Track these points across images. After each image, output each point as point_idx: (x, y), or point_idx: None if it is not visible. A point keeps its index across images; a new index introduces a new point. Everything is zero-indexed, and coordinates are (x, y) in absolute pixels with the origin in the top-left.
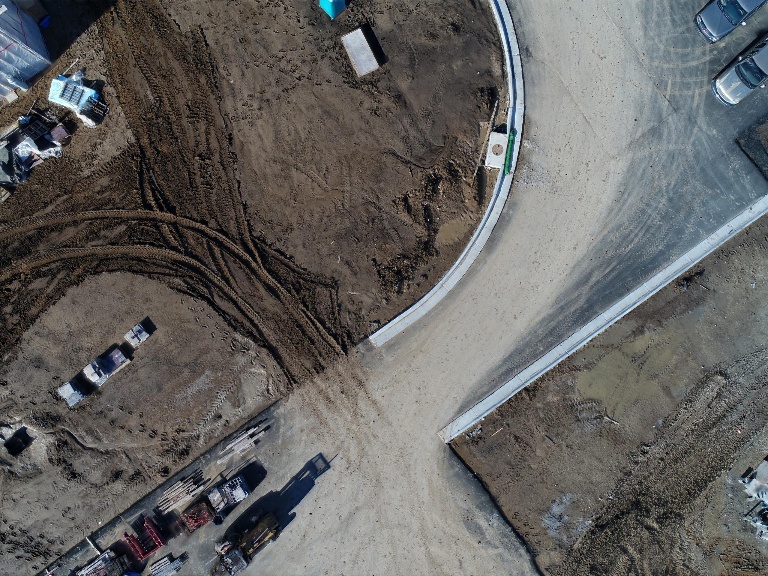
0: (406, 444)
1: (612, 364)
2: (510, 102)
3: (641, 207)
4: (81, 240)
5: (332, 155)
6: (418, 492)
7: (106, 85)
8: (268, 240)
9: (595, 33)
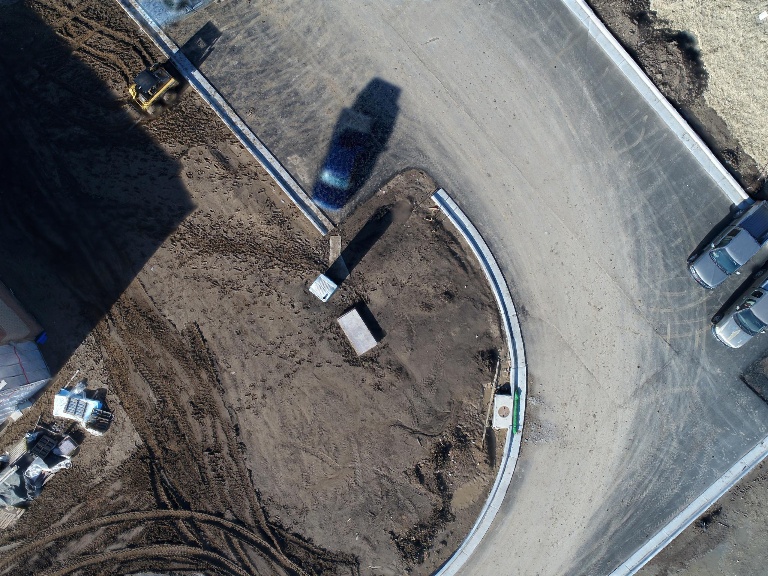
0: None
1: None
2: (511, 363)
3: (652, 452)
4: (100, 546)
5: (340, 434)
6: None
7: (109, 393)
8: (285, 525)
9: (589, 285)
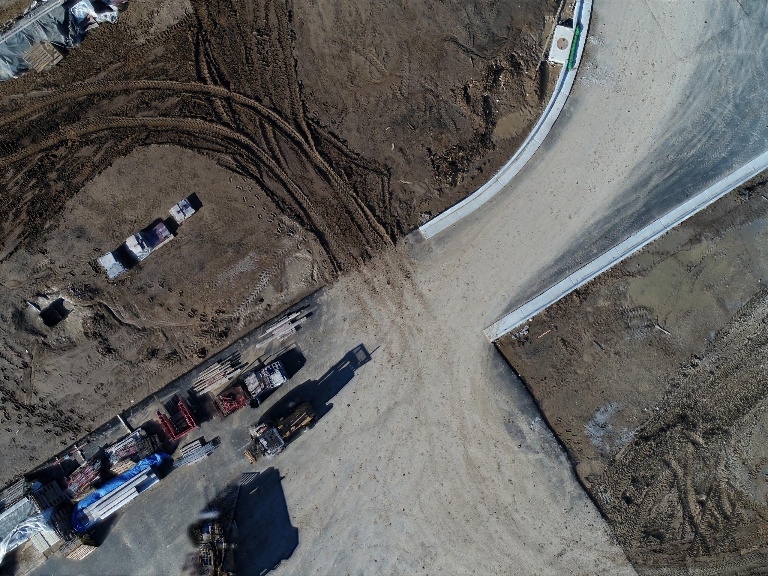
0: (450, 340)
1: (666, 272)
2: None
3: (706, 112)
4: (131, 110)
5: (392, 39)
6: (460, 390)
7: None
8: (322, 122)
9: None
